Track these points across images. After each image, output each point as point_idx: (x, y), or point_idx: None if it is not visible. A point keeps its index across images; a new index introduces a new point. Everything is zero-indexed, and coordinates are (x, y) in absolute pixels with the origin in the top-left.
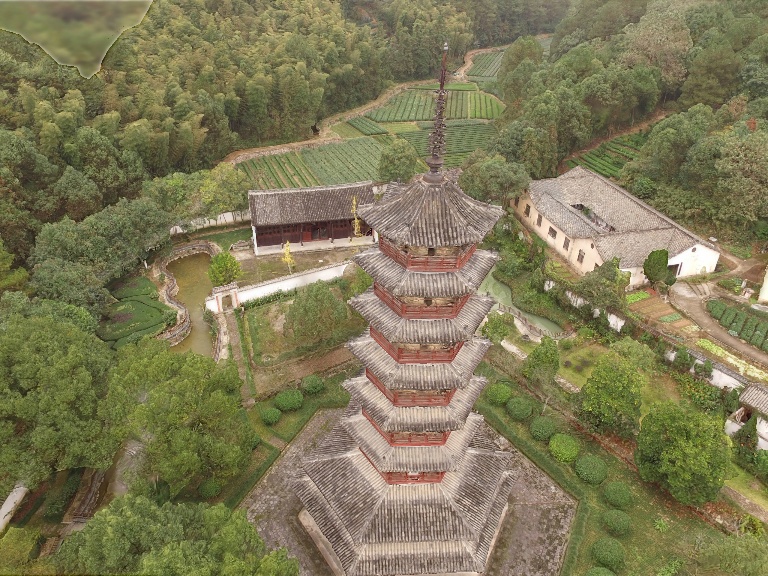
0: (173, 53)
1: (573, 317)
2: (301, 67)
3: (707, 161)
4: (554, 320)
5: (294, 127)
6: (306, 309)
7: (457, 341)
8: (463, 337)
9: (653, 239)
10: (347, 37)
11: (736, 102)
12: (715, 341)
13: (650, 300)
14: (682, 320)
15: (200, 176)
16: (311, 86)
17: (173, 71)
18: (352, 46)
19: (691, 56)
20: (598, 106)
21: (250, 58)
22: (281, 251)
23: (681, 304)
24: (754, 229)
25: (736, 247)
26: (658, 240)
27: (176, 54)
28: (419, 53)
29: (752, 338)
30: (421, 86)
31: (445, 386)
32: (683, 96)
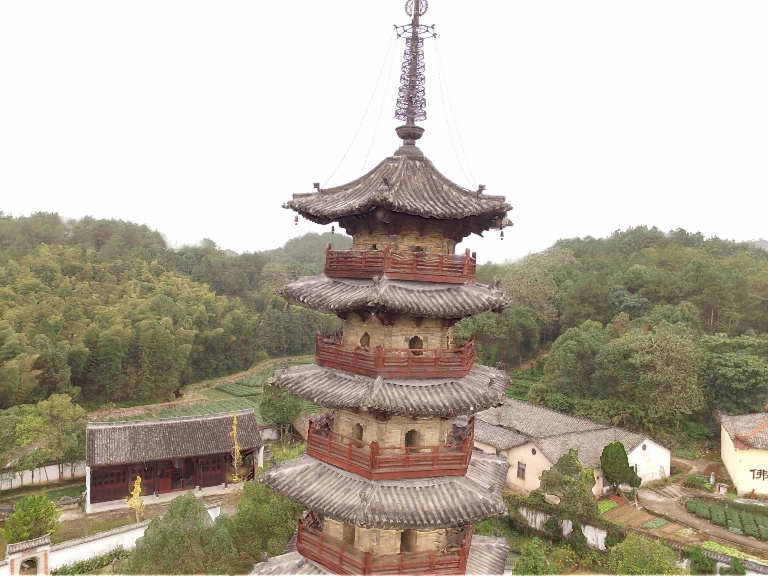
0: (12, 305)
1: (538, 539)
2: (166, 322)
3: (619, 362)
4: (513, 549)
5: (153, 386)
6: (166, 535)
7: (481, 407)
8: (490, 399)
9: (597, 440)
10: (218, 305)
11: (620, 318)
12: (722, 542)
13: (620, 508)
14: (669, 524)
15: (19, 411)
16: (176, 343)
17: (8, 319)
18: (223, 314)
19: (558, 300)
20: (486, 342)
21: (107, 313)
22: (125, 506)
23: (658, 508)
24: (687, 431)
25: (679, 450)
26: (602, 440)
27: (16, 306)
28: (291, 329)
29: (760, 533)
30: (294, 361)
31: (465, 515)
32: (565, 327)
